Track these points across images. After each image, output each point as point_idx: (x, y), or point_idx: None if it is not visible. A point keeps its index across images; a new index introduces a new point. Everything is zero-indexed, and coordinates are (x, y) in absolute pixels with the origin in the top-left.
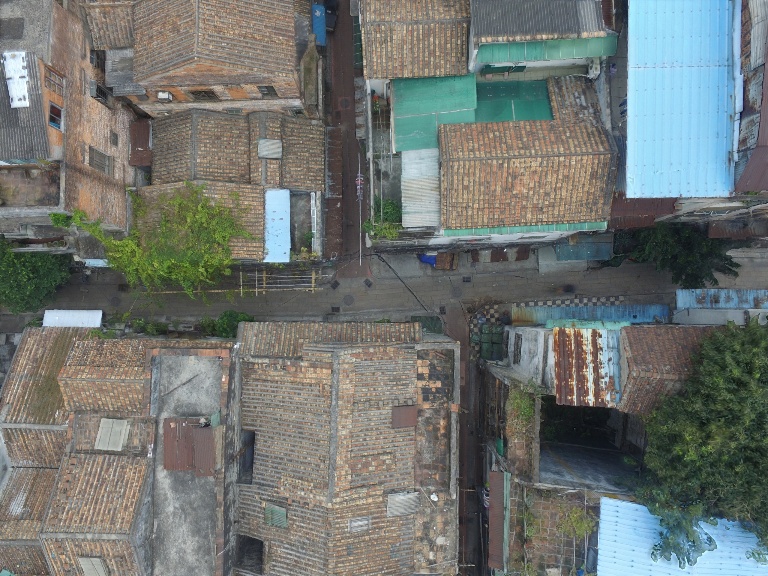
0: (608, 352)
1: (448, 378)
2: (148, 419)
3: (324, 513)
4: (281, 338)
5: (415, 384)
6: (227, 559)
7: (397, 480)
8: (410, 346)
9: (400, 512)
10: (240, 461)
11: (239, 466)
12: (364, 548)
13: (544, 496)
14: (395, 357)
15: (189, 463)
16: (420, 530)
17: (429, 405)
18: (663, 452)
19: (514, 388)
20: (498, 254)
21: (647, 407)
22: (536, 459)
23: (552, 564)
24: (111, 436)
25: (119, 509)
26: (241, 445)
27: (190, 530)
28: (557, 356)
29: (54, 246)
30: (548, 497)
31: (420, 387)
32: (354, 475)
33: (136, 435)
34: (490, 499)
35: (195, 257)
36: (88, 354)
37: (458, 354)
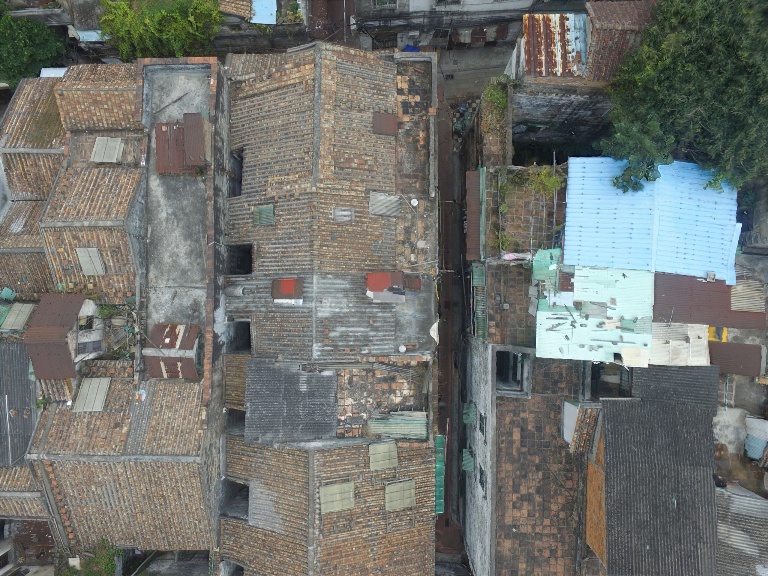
0: (575, 33)
1: (426, 93)
2: (141, 137)
3: (309, 199)
4: (267, 64)
5: (395, 97)
6: (218, 258)
7: (379, 182)
8: (389, 57)
9: (382, 212)
10: (230, 184)
11: (229, 187)
12: (348, 237)
13: (517, 181)
14: (375, 67)
15: (180, 165)
16: (401, 234)
17: (409, 118)
18: (626, 106)
19: (488, 86)
20: (478, 34)
21: (611, 72)
22: (509, 143)
23: (526, 249)
24: (106, 151)
25: (114, 205)
26: (231, 170)
27: (182, 235)
28: (527, 37)
29: (49, 7)
30: (521, 184)
31: (400, 101)
32: (337, 168)
33: (130, 153)
34: (467, 198)
35: (184, 2)
36: (83, 74)
37: (435, 61)
